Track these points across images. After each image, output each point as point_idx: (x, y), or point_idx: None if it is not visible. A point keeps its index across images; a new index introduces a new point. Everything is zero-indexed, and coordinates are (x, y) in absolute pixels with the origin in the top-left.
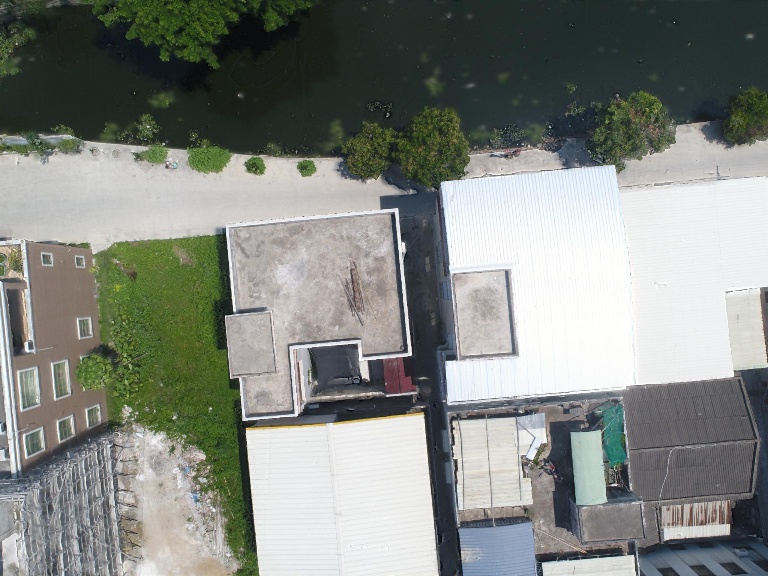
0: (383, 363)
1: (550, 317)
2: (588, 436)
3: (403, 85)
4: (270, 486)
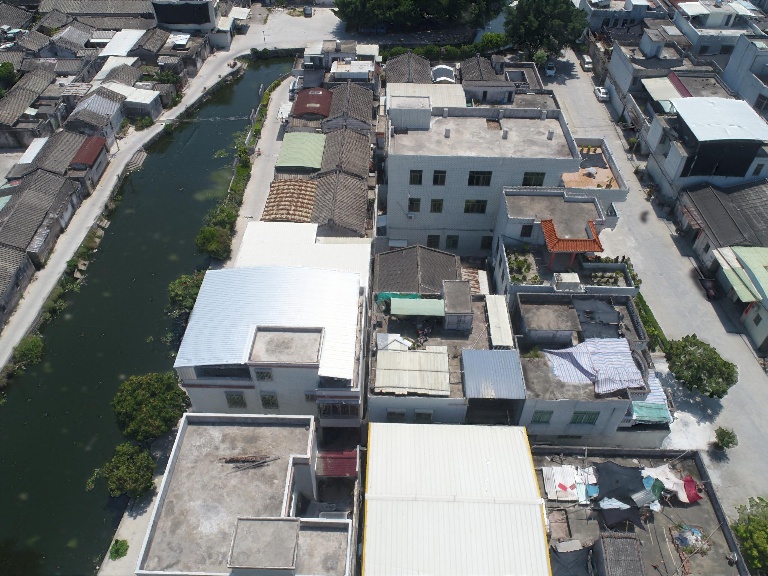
0: (328, 475)
1: (300, 309)
2: (394, 303)
3: (84, 457)
4: (426, 570)
